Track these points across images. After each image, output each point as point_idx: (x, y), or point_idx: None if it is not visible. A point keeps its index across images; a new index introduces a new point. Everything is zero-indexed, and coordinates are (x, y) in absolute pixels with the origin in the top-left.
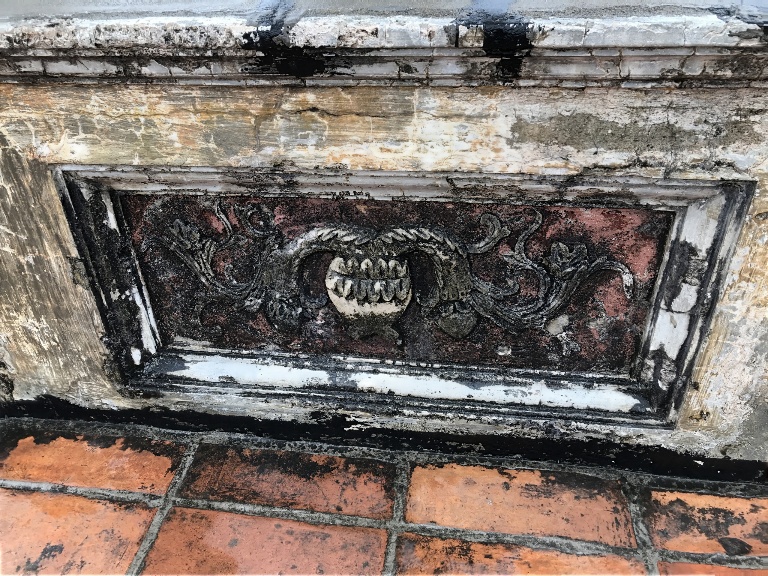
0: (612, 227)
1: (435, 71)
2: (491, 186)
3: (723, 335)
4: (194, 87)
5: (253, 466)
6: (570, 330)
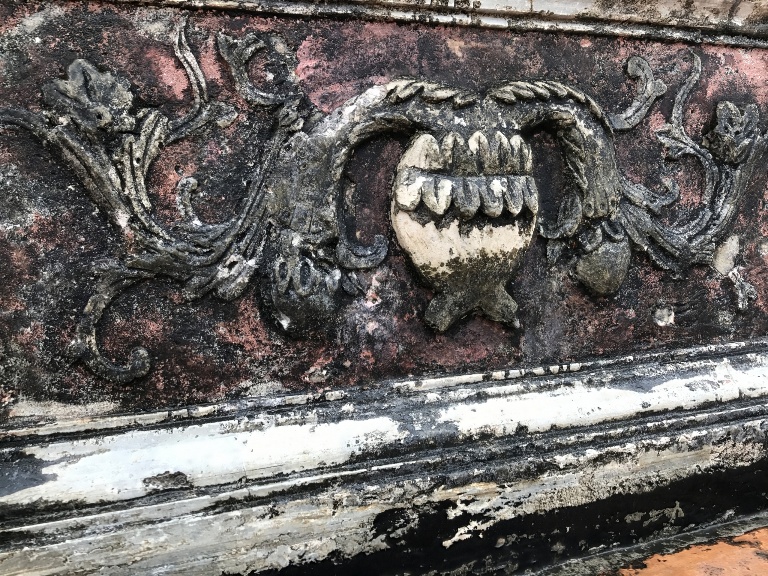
0: None
1: None
2: None
3: None
4: None
5: None
6: (741, 263)
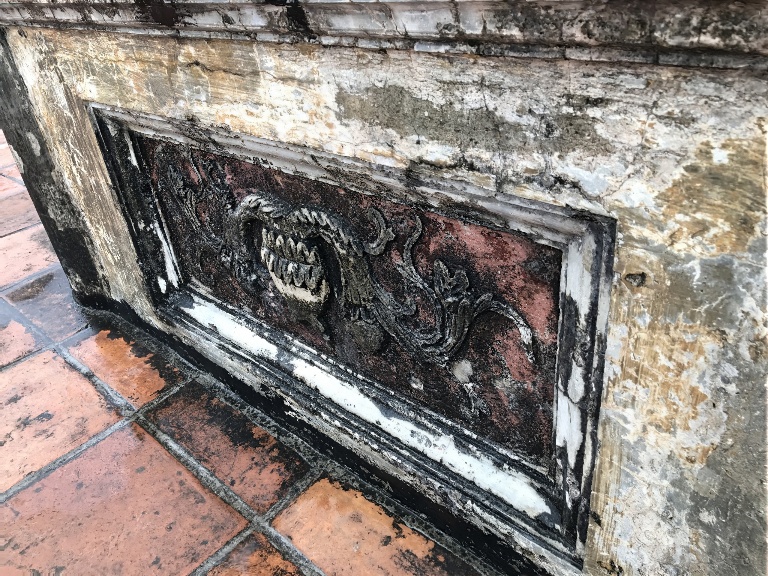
0: (495, 255)
1: (246, 22)
2: (349, 171)
3: (618, 456)
4: (129, 35)
5: (208, 415)
6: (476, 382)
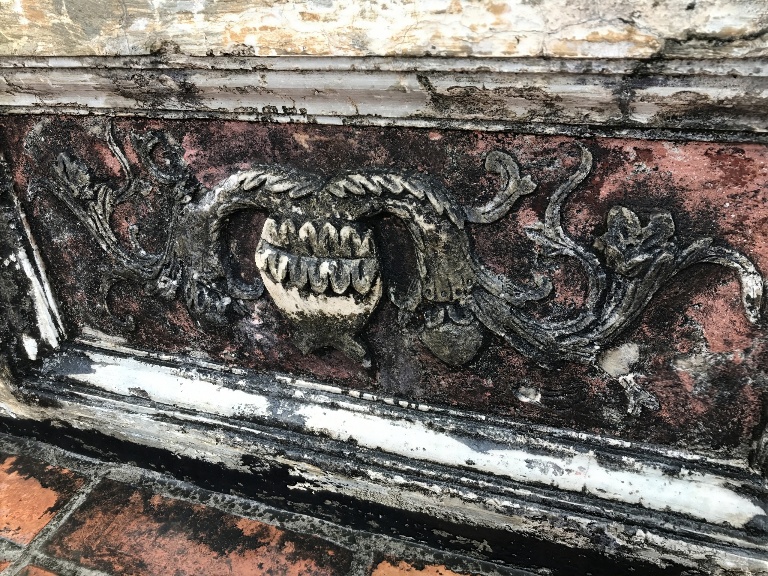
0: (725, 181)
1: None
2: (494, 90)
3: None
4: None
5: (155, 522)
6: (641, 371)
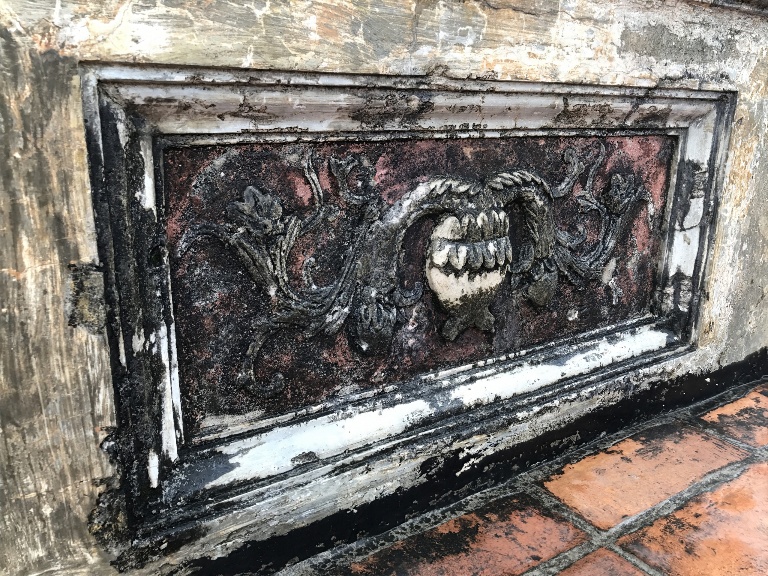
0: (644, 155)
1: None
2: (592, 106)
3: (721, 239)
4: None
5: None
6: (616, 275)
